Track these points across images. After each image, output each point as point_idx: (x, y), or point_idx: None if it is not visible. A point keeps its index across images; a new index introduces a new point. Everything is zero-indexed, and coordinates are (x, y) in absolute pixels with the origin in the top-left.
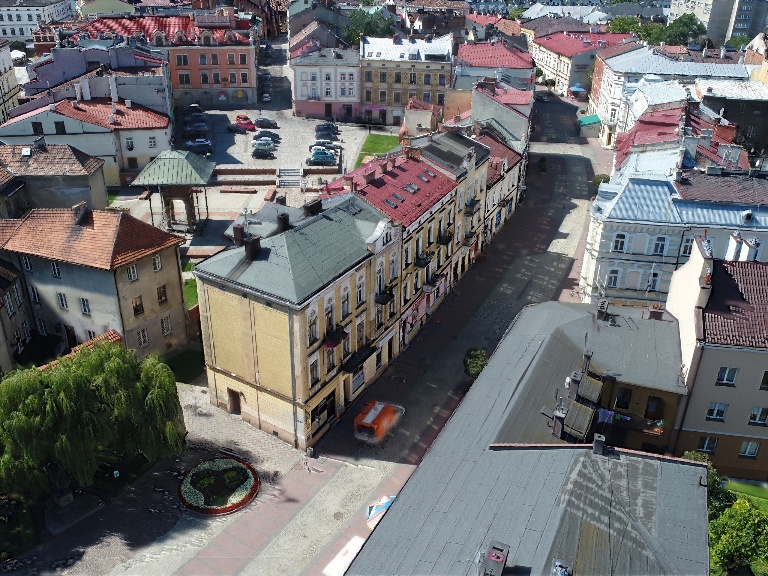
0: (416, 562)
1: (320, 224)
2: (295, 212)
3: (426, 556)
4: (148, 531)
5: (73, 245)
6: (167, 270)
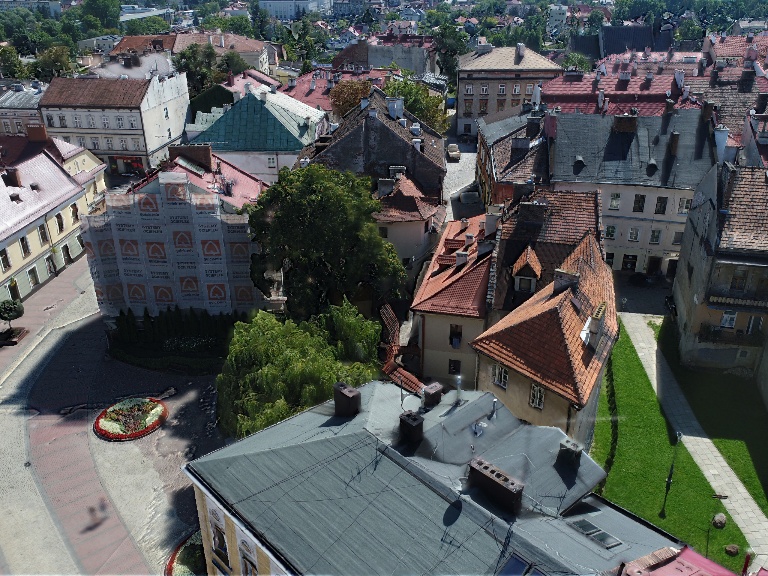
0: None
1: (422, 495)
2: (499, 465)
3: None
4: (190, 502)
5: (527, 307)
6: (550, 420)
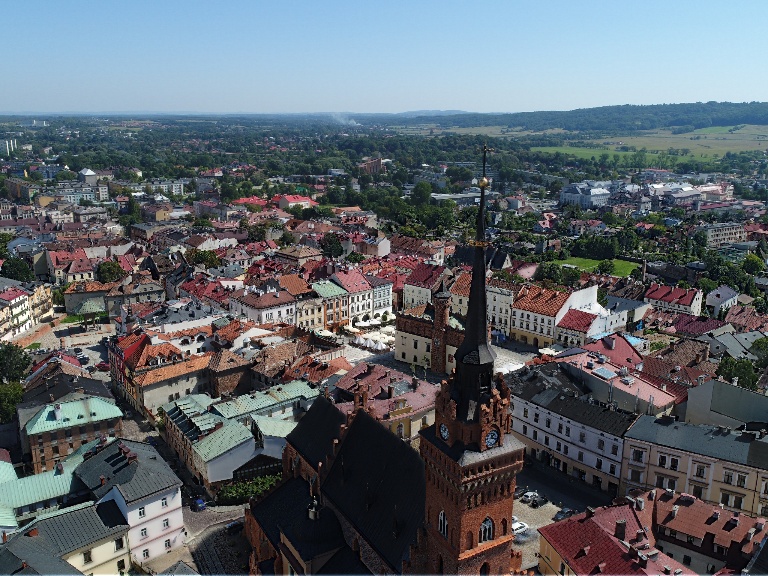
0: (6, 285)
1: None
2: None
3: (4, 285)
4: None
5: None
6: None
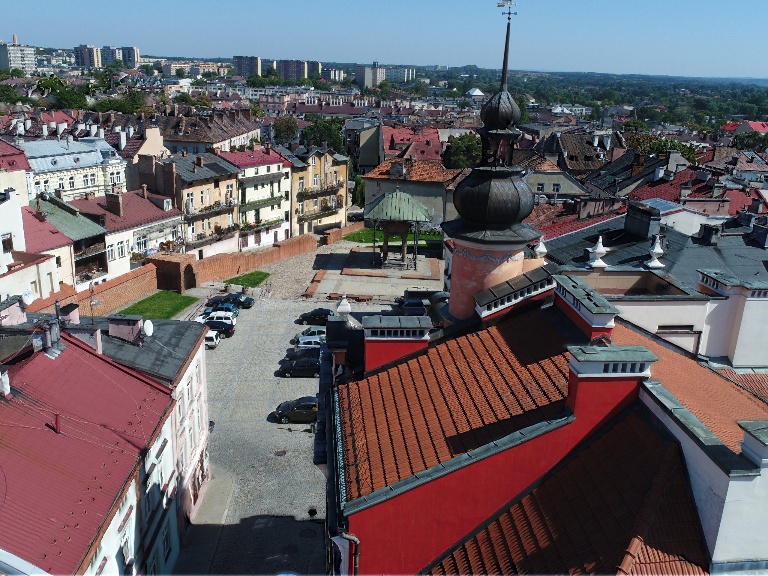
0: None
1: None
2: None
3: None
4: None
5: None
6: None
